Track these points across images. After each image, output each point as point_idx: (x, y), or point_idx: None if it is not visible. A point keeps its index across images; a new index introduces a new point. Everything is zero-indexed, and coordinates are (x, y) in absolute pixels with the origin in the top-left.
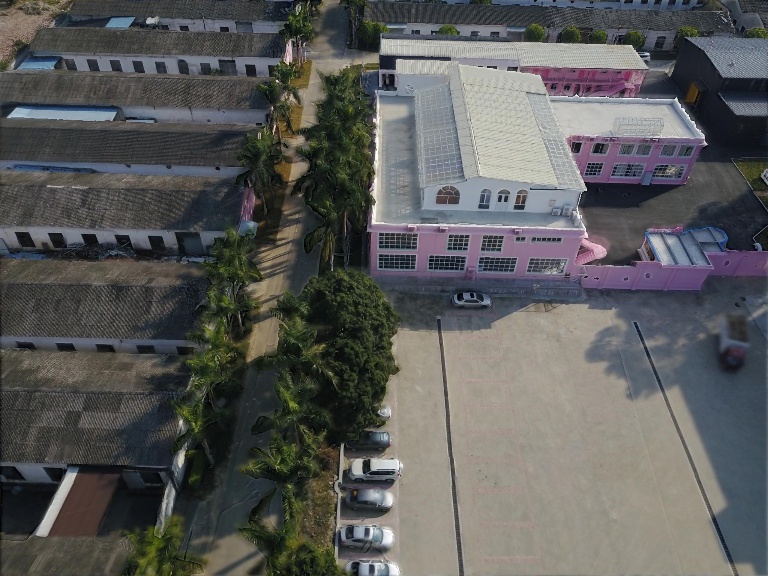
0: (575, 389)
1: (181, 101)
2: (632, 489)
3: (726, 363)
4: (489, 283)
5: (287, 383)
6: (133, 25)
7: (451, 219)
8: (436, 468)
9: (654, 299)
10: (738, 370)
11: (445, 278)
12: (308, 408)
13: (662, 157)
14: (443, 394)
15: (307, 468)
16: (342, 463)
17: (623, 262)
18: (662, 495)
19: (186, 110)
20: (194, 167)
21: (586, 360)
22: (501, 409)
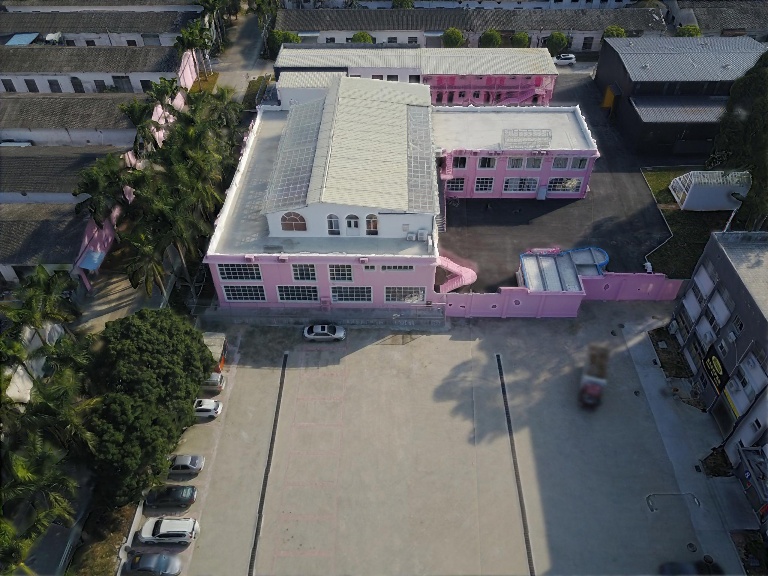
0: (414, 433)
1: (57, 122)
2: (450, 550)
3: (587, 401)
4: (345, 314)
5: (34, 446)
6: (38, 41)
7: (296, 247)
8: (240, 527)
9: (524, 328)
10: (598, 409)
11: (299, 309)
12: (54, 475)
13: (555, 170)
14: (269, 440)
15: (18, 550)
16: (136, 523)
17: (497, 287)
18: (482, 557)
19: (63, 131)
20: (49, 194)
21: (434, 399)
22: (327, 457)
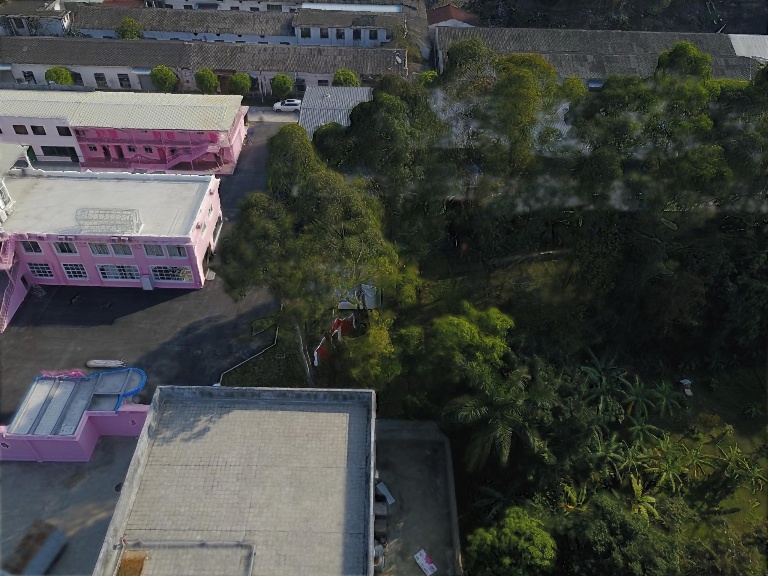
0: None
1: None
2: None
3: None
4: None
5: None
6: None
7: None
8: None
9: (13, 477)
10: None
11: None
12: None
13: (151, 258)
14: None
15: None
16: None
17: (9, 417)
18: None
19: None
20: None
21: None
22: None
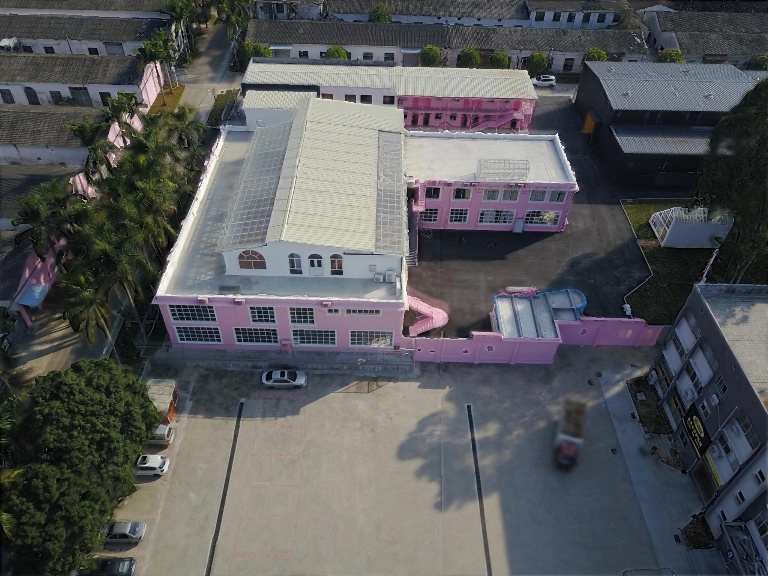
0: (376, 495)
1: (5, 137)
2: None
3: (561, 459)
4: (307, 358)
5: None
6: None
7: (255, 287)
8: None
9: (497, 375)
10: (573, 468)
11: (258, 352)
12: None
13: (532, 203)
14: (219, 503)
15: None
16: None
17: (469, 329)
18: None
19: (11, 147)
20: None
21: (399, 456)
22: (282, 523)
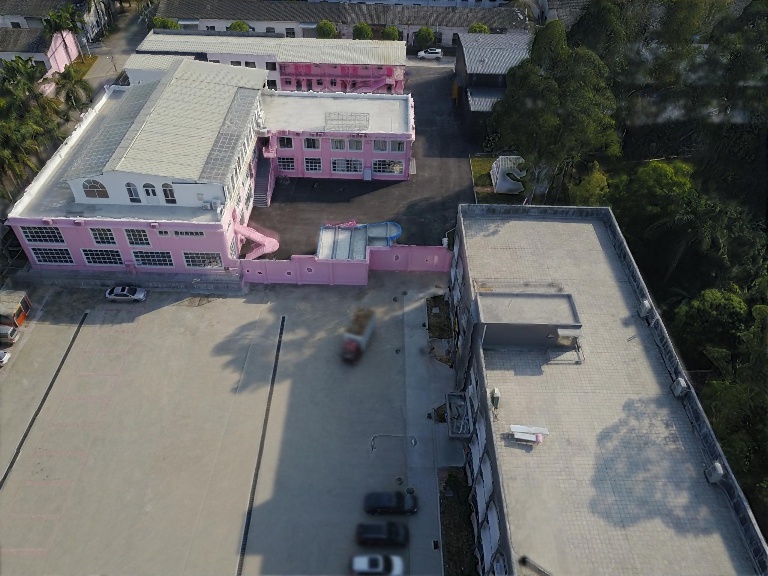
0: (182, 383)
1: None
2: (182, 482)
3: (350, 357)
4: (149, 277)
5: None
6: None
7: (97, 213)
8: None
9: (316, 293)
10: (358, 364)
11: (107, 272)
12: None
13: (376, 152)
14: (47, 387)
15: None
16: None
17: None
18: (210, 488)
19: None
20: None
21: (210, 354)
22: (96, 402)
